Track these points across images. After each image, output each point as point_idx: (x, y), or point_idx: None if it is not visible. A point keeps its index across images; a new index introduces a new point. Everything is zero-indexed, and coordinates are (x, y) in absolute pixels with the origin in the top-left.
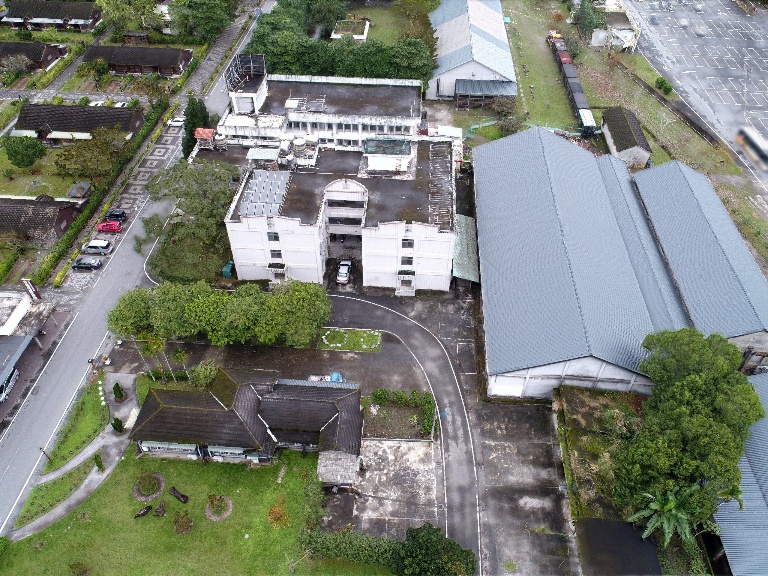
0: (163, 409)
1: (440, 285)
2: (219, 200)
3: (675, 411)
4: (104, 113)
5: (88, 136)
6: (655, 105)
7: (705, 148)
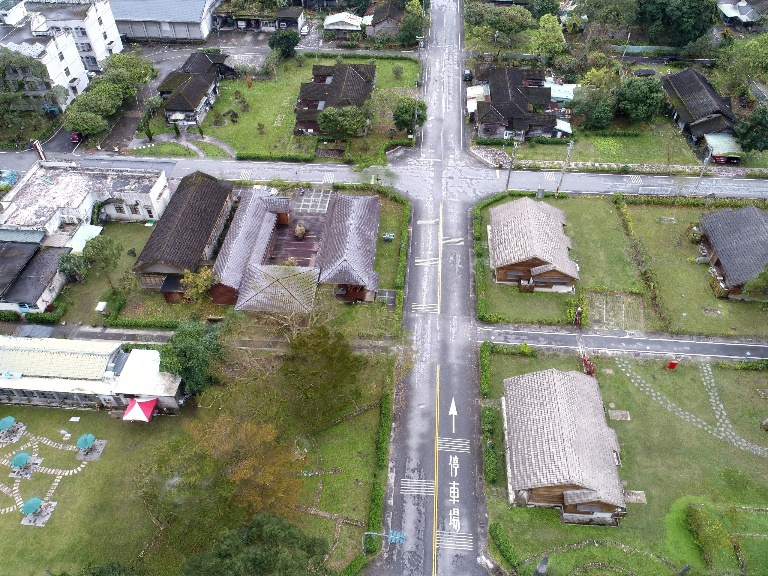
0: (183, 93)
1: (119, 47)
2: None
3: None
4: None
5: None
6: None
7: None
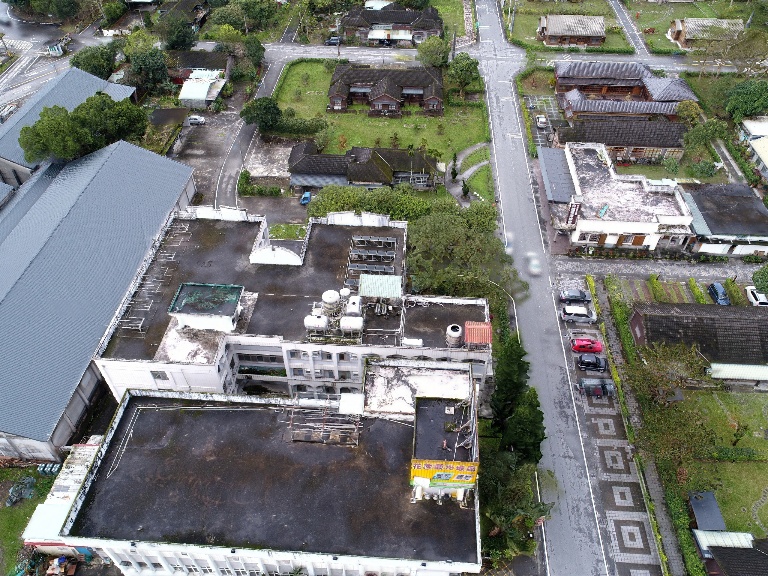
0: None
1: None
2: None
3: None
4: None
5: None
6: None
7: None
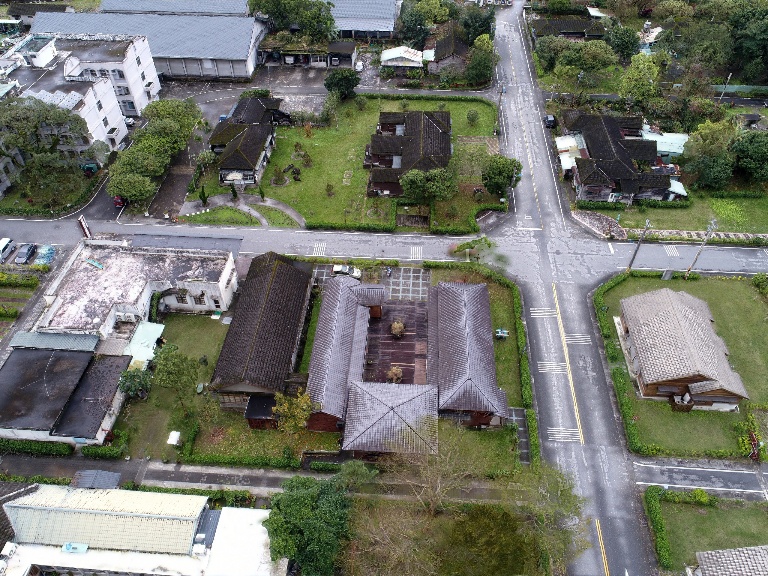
0: (240, 149)
1: (157, 87)
2: (54, 107)
3: (292, 4)
4: None
5: None
6: (2, 7)
7: (71, 2)
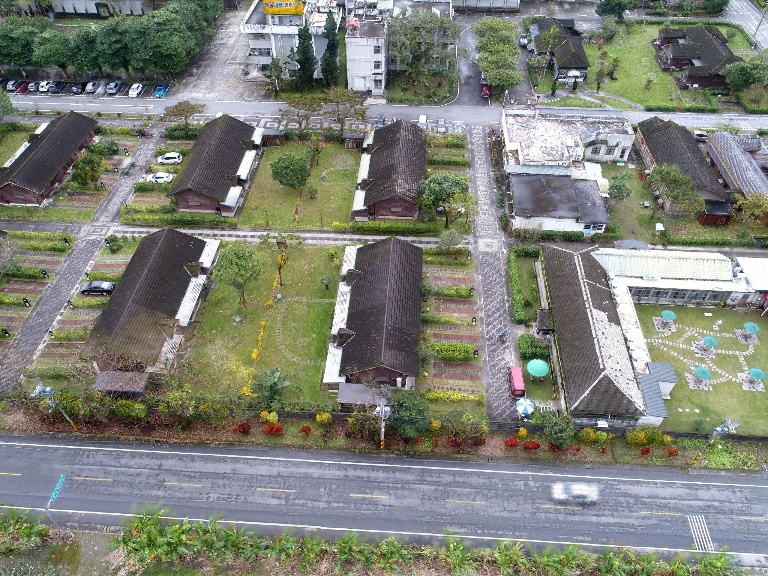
0: None
1: None
2: None
3: None
4: (225, 134)
5: (251, 152)
6: None
7: None
